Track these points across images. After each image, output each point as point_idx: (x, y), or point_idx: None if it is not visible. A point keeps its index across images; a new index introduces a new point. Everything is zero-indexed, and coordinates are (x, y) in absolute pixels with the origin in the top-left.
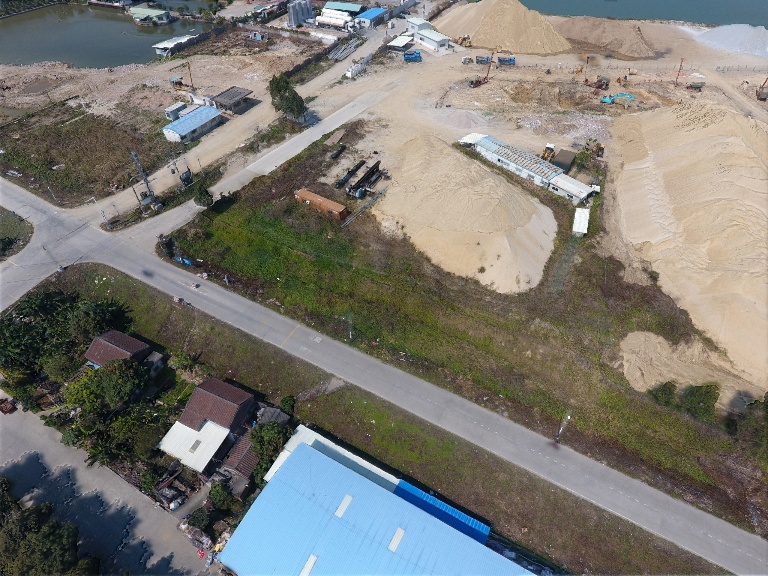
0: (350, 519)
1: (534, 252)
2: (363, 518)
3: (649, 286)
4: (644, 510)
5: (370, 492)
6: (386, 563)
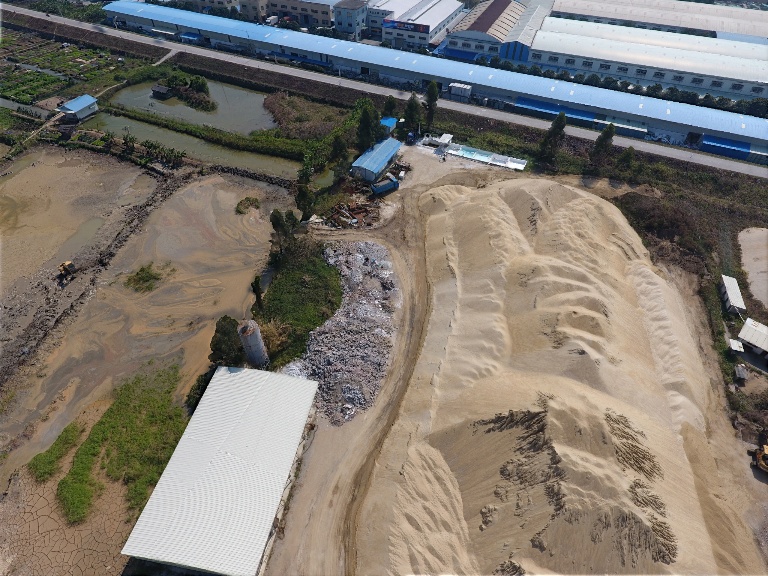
0: (765, 128)
1: (761, 250)
2: (760, 129)
3: (656, 223)
4: (643, 145)
5: (764, 136)
6: (743, 121)
